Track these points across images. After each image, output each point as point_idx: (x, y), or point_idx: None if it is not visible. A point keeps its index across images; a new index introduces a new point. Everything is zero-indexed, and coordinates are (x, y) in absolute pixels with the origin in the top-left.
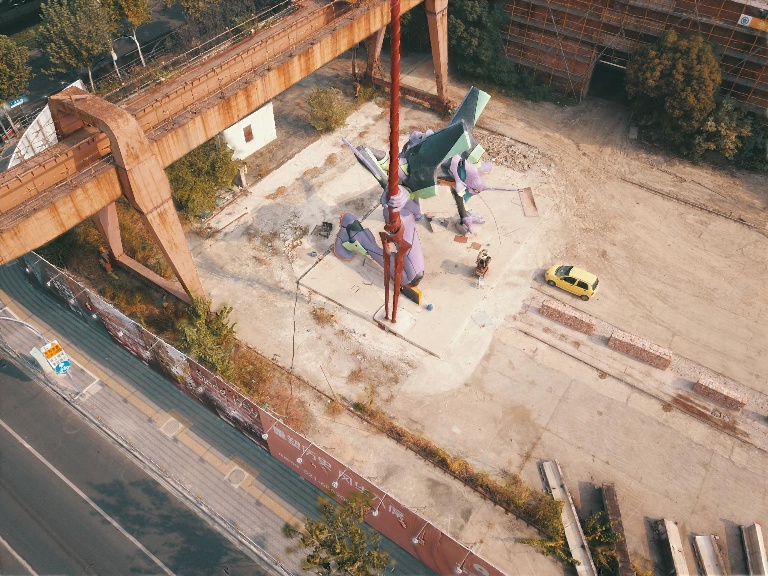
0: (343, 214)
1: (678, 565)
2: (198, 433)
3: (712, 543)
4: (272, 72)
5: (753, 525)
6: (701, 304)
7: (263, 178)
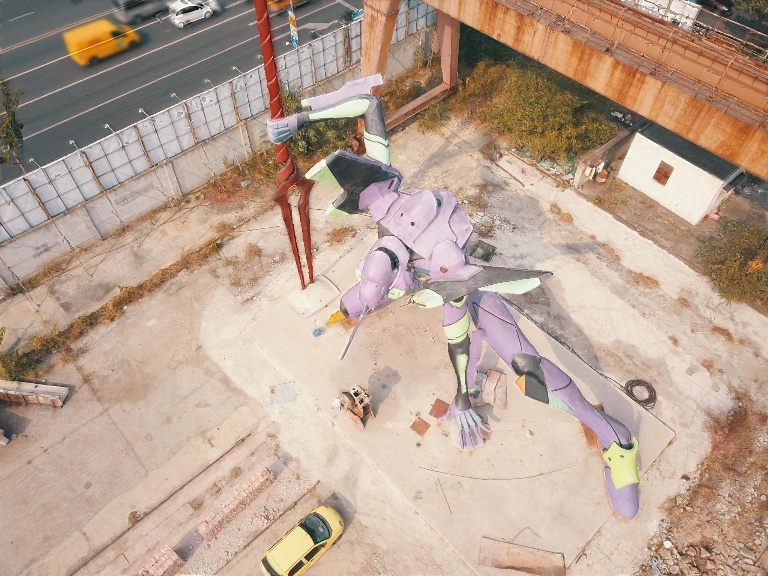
0: None
1: None
2: None
3: None
4: (565, 37)
5: None
6: None
7: (594, 203)
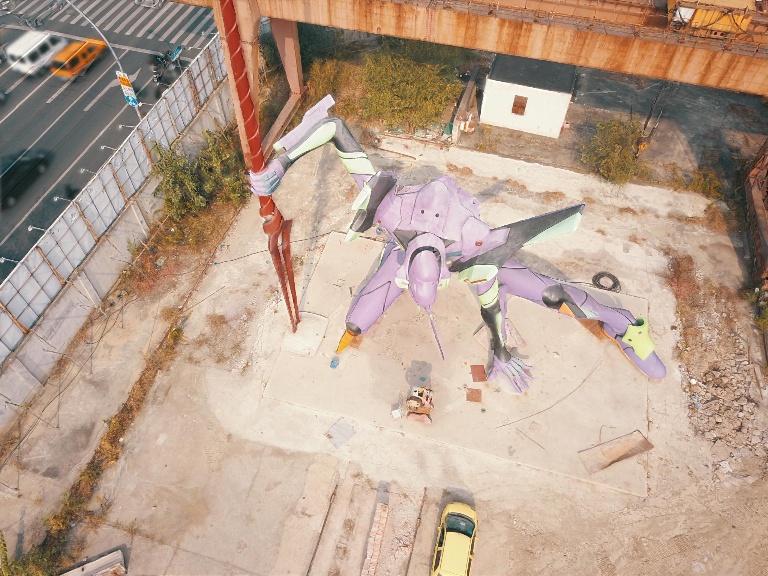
0: None
1: None
2: None
3: None
4: (448, 12)
5: None
6: None
7: (478, 151)
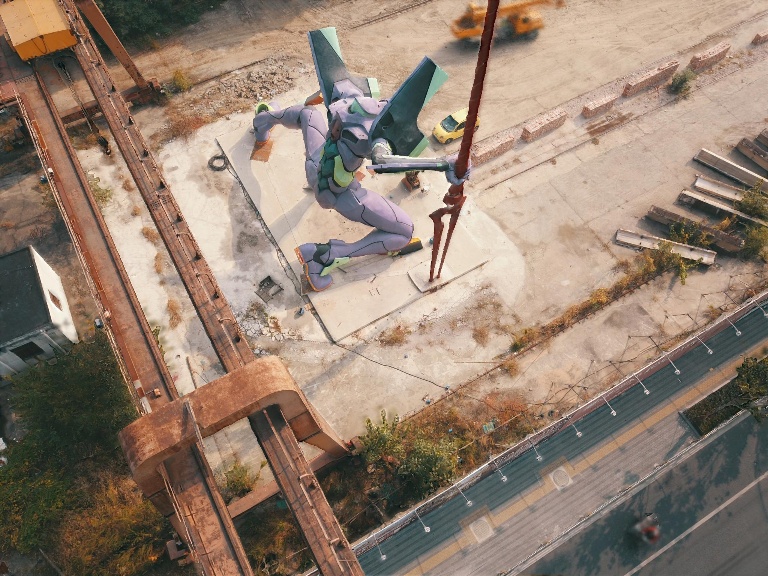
0: (299, 252)
1: (716, 205)
2: (499, 503)
3: (705, 179)
4: None
5: (702, 151)
6: (514, 67)
7: None
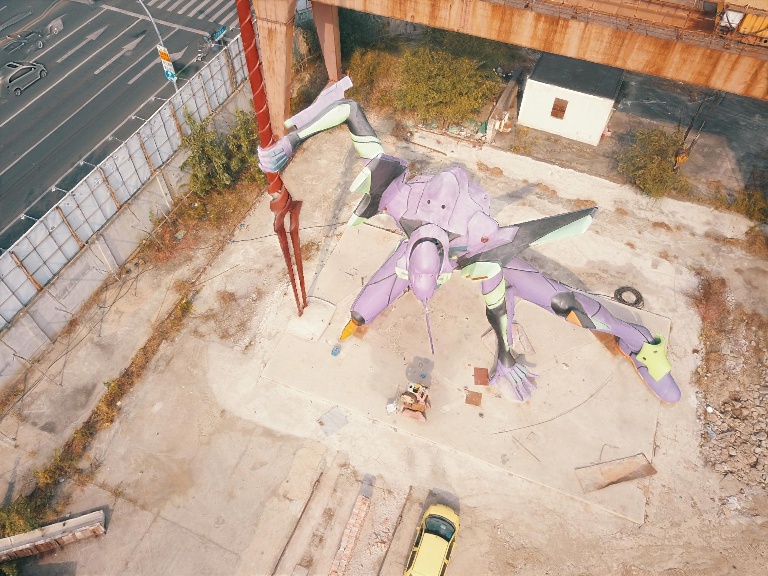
0: None
1: None
2: None
3: None
4: (483, 3)
5: None
6: None
7: (511, 152)
